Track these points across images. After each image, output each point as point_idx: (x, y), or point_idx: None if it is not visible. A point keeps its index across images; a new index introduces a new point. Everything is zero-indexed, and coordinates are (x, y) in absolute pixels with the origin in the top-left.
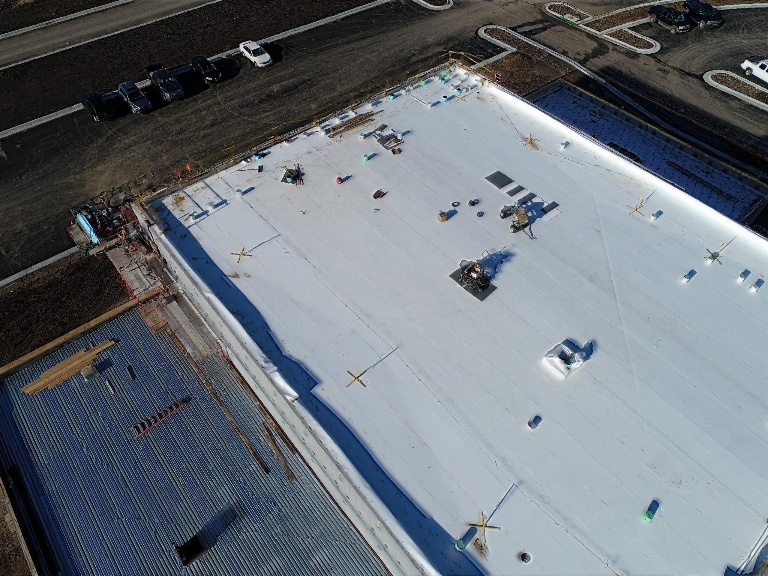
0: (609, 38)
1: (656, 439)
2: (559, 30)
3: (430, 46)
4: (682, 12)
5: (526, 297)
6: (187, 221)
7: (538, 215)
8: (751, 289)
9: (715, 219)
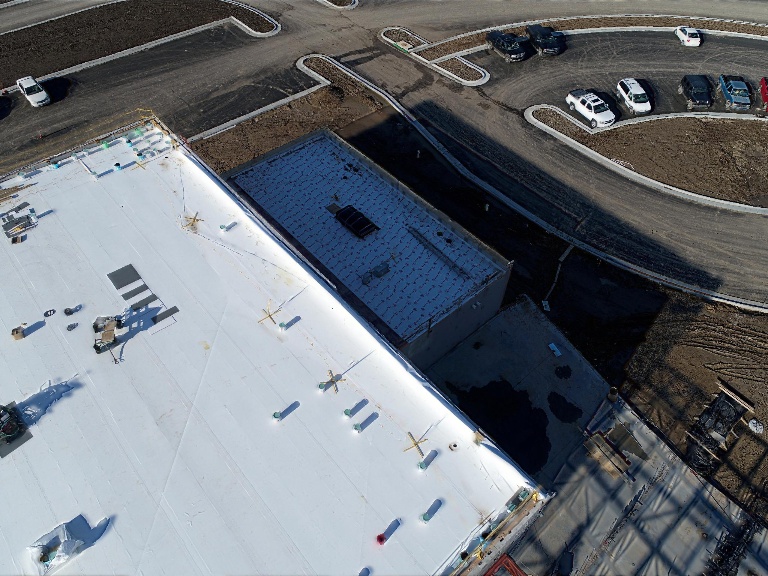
0: (438, 68)
1: None
2: (387, 59)
3: (238, 79)
4: (525, 37)
5: (62, 450)
6: None
7: (144, 326)
8: (353, 429)
9: (355, 328)
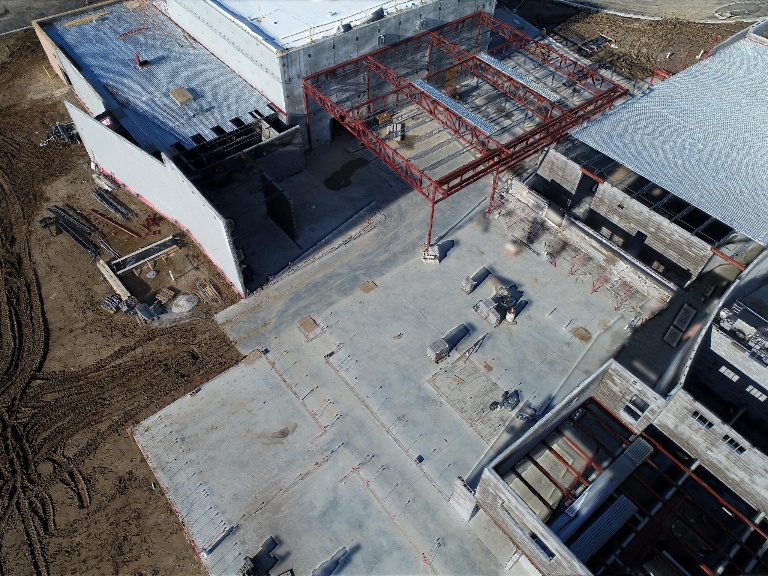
0: None
1: (347, 0)
2: None
3: None
4: None
5: None
6: None
7: None
8: None
9: None
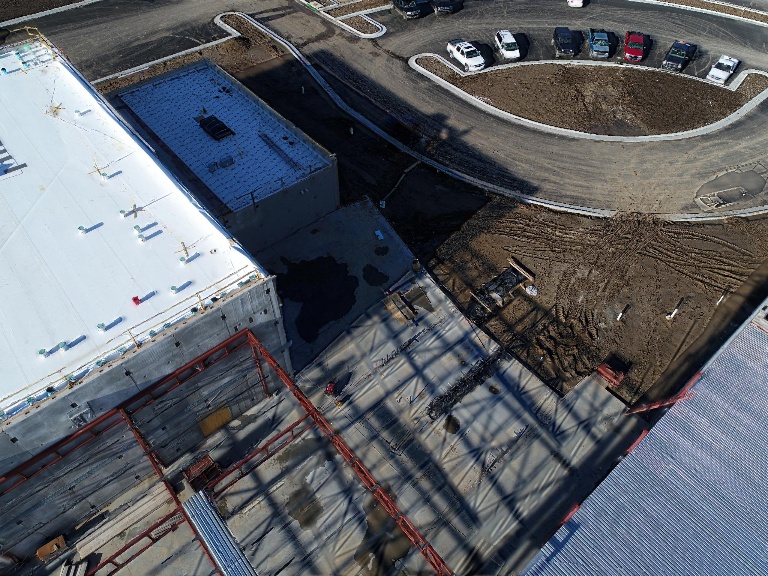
0: (341, 24)
1: None
2: (297, 16)
3: (159, 31)
4: None
5: None
6: None
7: None
8: (139, 239)
9: (162, 177)
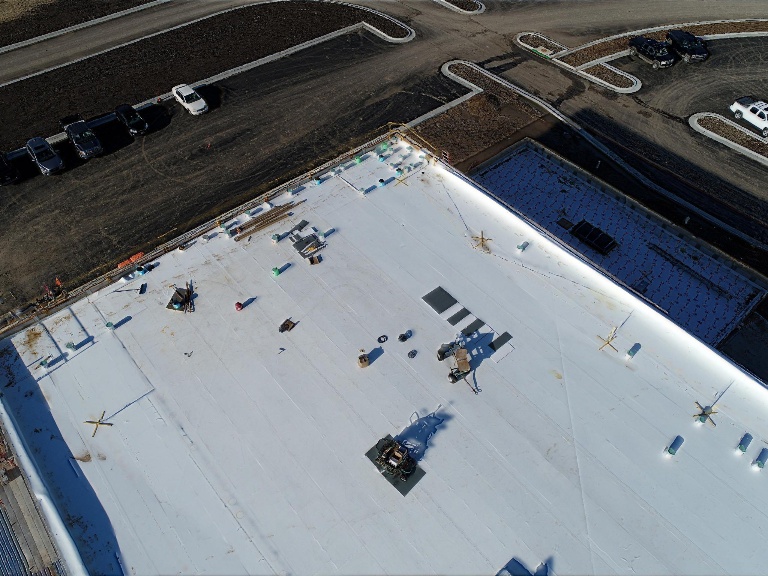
0: (585, 75)
1: None
2: (531, 65)
3: (387, 86)
4: (665, 43)
5: (463, 488)
6: (38, 370)
7: (485, 353)
8: (754, 467)
9: (706, 357)
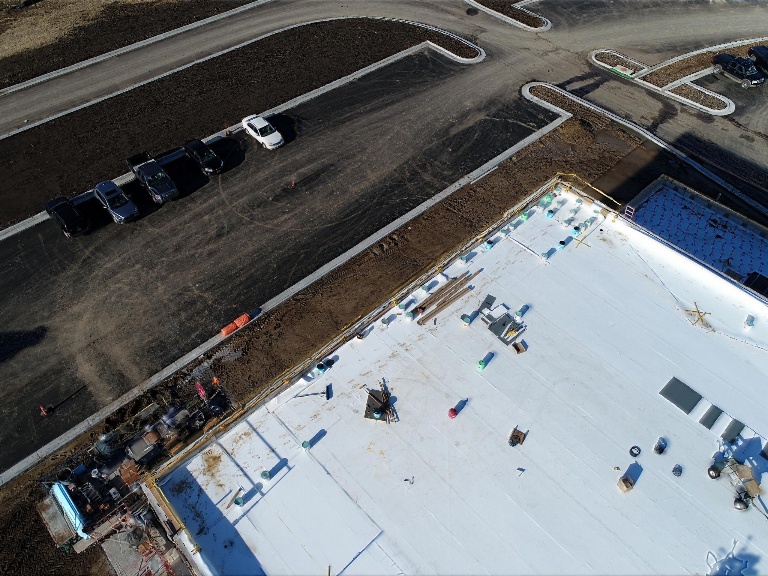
0: (673, 95)
1: None
2: (614, 86)
3: (469, 112)
4: (746, 59)
5: None
6: (231, 509)
7: (760, 466)
8: None
9: None
